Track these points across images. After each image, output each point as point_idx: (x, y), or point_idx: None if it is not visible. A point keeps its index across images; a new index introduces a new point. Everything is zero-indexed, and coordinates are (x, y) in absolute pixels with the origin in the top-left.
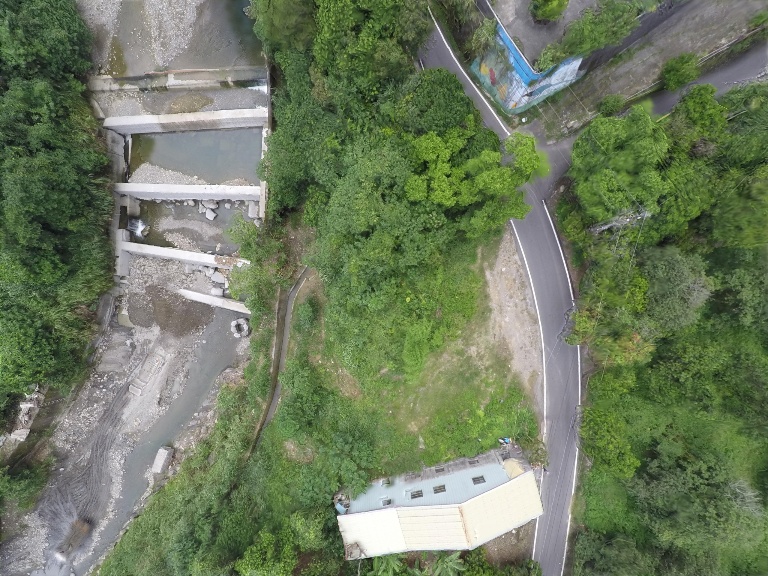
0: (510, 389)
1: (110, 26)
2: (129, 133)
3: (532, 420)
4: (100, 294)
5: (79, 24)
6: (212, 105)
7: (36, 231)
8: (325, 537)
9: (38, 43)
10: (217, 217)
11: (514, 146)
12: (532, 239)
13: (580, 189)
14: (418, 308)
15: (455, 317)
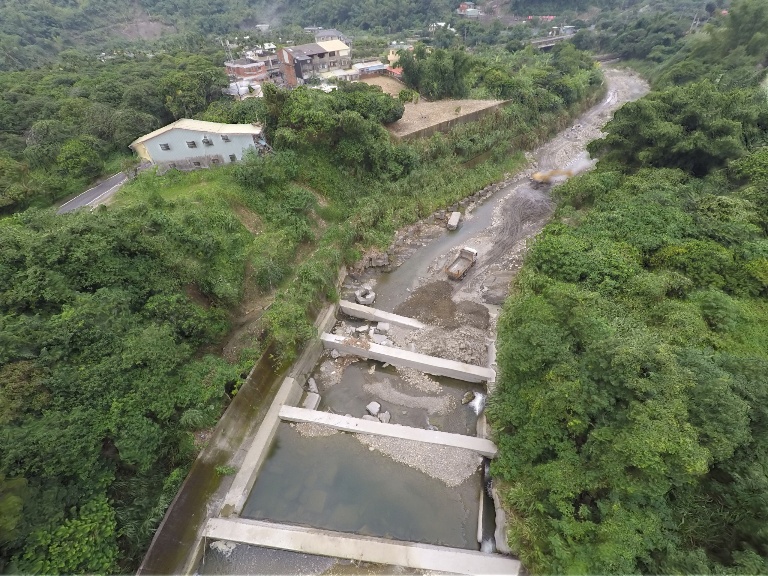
0: None
1: None
2: None
3: None
4: None
5: None
6: (304, 572)
7: None
8: None
9: None
10: None
11: None
12: None
13: None
14: None
15: None
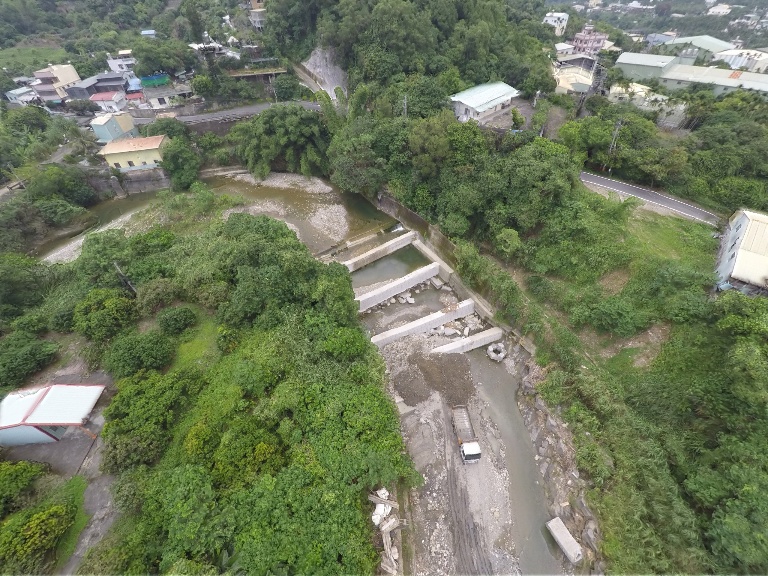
0: (677, 221)
1: None
2: None
3: None
4: None
5: None
6: (378, 245)
7: None
8: None
9: None
10: None
11: None
12: (594, 180)
13: (594, 138)
14: (597, 204)
15: None
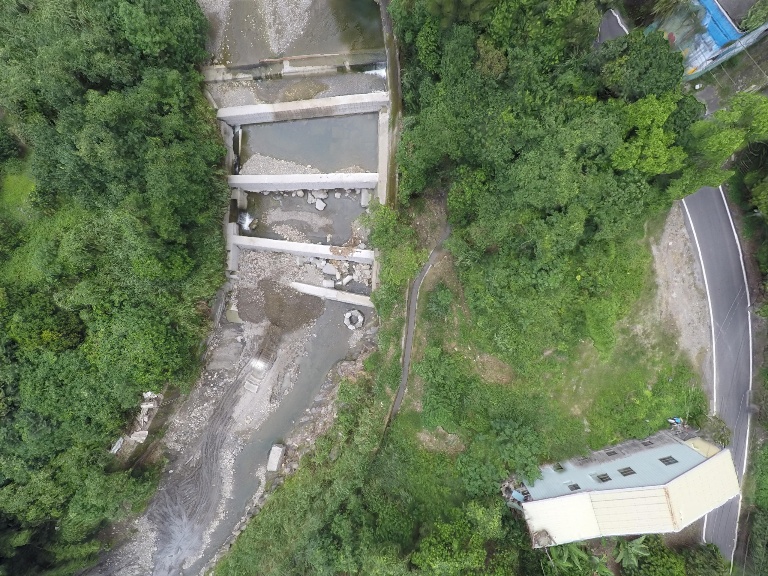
0: (679, 367)
1: (223, 14)
2: (239, 124)
3: (702, 398)
4: (216, 289)
5: (199, 12)
6: (327, 91)
7: (176, 223)
8: (502, 526)
9: (169, 31)
10: (326, 207)
11: (749, 105)
12: (701, 211)
13: None
14: (592, 286)
15: (627, 294)
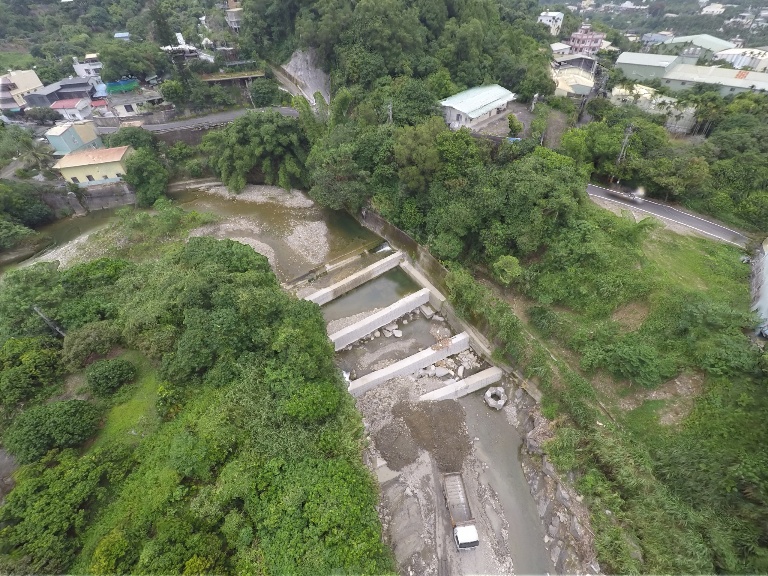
0: (699, 241)
1: (272, 263)
2: None
3: None
4: None
5: None
6: (361, 268)
7: None
8: None
9: None
10: (402, 334)
11: None
12: (601, 194)
13: (601, 147)
14: (608, 224)
15: None
